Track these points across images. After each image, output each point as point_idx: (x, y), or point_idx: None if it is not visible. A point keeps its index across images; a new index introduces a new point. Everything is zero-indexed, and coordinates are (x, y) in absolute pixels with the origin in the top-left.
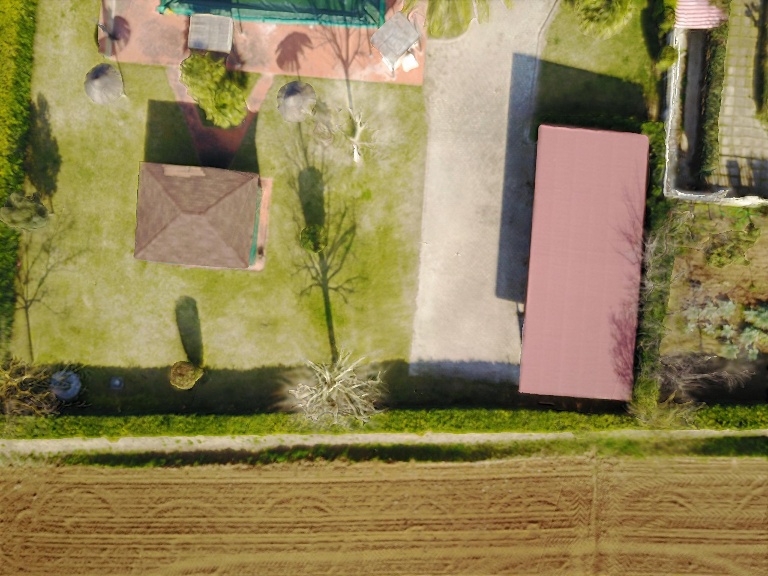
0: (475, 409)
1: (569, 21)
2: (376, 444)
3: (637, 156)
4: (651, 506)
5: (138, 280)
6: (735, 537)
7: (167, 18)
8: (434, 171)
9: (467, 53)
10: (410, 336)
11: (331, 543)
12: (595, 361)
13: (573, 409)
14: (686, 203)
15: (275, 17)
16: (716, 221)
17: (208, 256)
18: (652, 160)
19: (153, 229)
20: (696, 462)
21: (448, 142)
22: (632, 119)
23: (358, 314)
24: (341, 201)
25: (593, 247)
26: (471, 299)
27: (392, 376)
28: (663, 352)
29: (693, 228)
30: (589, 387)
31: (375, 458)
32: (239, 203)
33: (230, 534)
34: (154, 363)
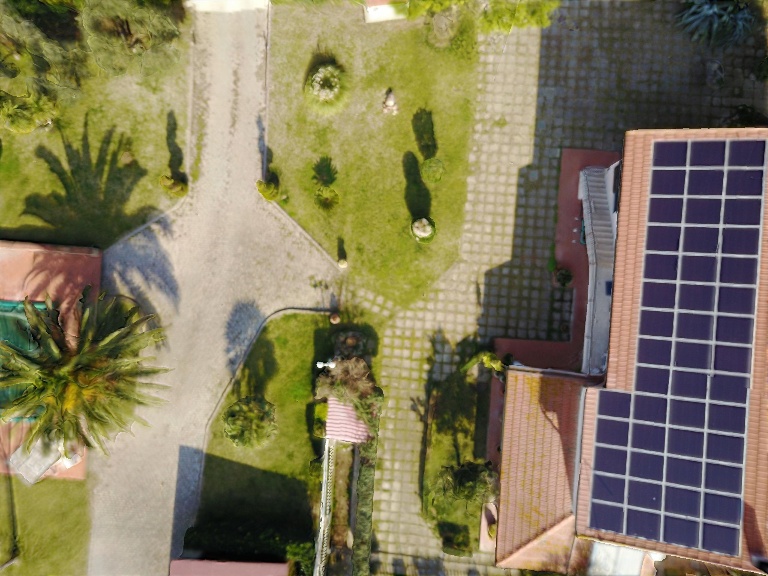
0: None
1: None
2: None
3: None
4: None
5: None
6: None
7: None
8: (97, 569)
9: (133, 445)
10: None
11: None
12: None
13: None
14: None
15: None
16: None
17: None
18: None
19: None
20: None
21: (113, 537)
22: (278, 540)
23: None
24: None
25: None
26: None
27: None
28: None
29: None
30: None
31: None
32: None
33: None
34: None
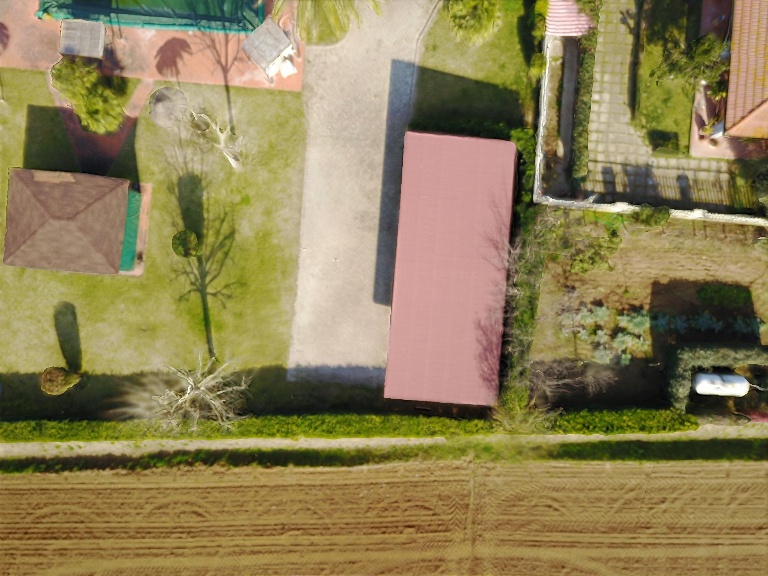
0: (347, 414)
1: (447, 28)
2: (256, 449)
3: (504, 163)
4: (526, 510)
5: (17, 285)
6: (607, 541)
7: (46, 23)
8: (313, 177)
9: (346, 59)
10: (288, 341)
11: (208, 548)
12: (461, 366)
13: (449, 414)
14: (561, 209)
15: (154, 22)
16: (591, 227)
17: (78, 262)
18: (523, 166)
19: (22, 235)
20: (571, 466)
21: (327, 148)
22: (501, 126)
23: (237, 319)
24: (220, 206)
25: (459, 253)
26: (349, 304)
27: (270, 381)
28: (538, 357)
29: (568, 234)
30: (454, 392)
31: (254, 463)
32: (109, 209)
33: (108, 539)
34: (32, 368)
